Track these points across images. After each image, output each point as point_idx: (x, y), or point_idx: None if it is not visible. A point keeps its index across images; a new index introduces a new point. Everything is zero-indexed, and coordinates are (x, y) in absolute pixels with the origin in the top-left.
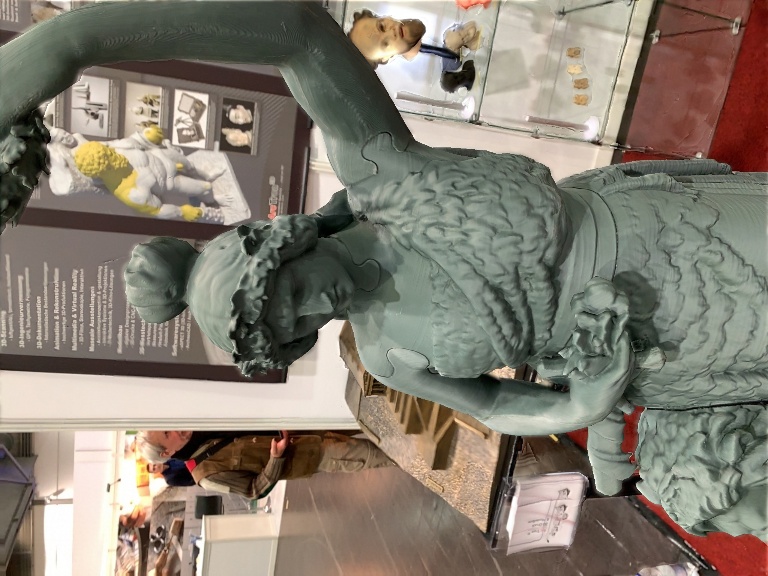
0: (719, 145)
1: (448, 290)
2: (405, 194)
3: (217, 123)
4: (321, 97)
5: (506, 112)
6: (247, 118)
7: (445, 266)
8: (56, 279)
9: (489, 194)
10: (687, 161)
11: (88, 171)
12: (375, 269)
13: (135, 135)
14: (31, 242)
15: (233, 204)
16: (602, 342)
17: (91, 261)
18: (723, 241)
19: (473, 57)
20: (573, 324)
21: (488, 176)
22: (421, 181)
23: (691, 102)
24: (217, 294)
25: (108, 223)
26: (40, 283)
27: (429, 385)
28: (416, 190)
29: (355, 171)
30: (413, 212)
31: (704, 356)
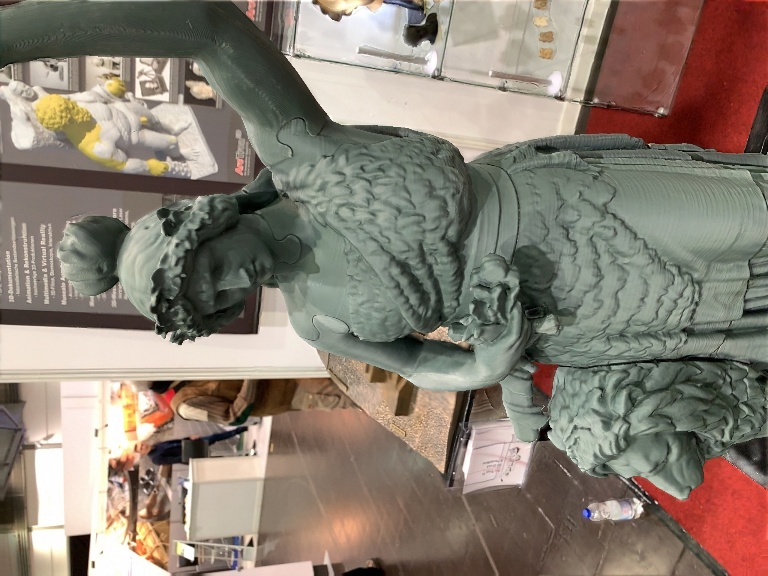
0: (680, 100)
1: (360, 264)
2: (318, 176)
3: (180, 75)
4: (233, 87)
5: (474, 64)
6: None
7: (355, 243)
8: (24, 234)
9: (394, 177)
10: (601, 136)
11: (50, 125)
12: (296, 244)
13: (97, 88)
14: None
15: (200, 158)
16: (495, 312)
17: (58, 216)
18: (618, 217)
19: (436, 10)
20: None
21: (394, 159)
22: (332, 164)
23: (660, 54)
24: (140, 272)
25: (74, 178)
26: (8, 238)
27: (353, 347)
28: (328, 173)
29: (272, 154)
30: (326, 193)
31: (599, 321)
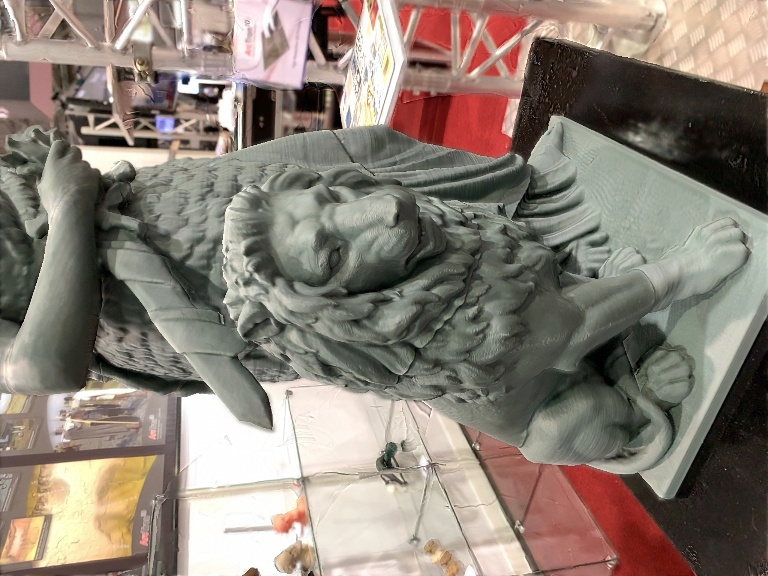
0: (611, 534)
1: None
2: None
3: None
4: None
5: None
6: None
7: None
8: None
9: None
10: None
11: None
12: None
13: None
14: None
15: None
16: (33, 138)
17: None
18: None
19: None
20: None
21: None
22: None
23: None
24: None
25: None
26: None
27: None
28: None
29: None
30: None
31: (197, 181)
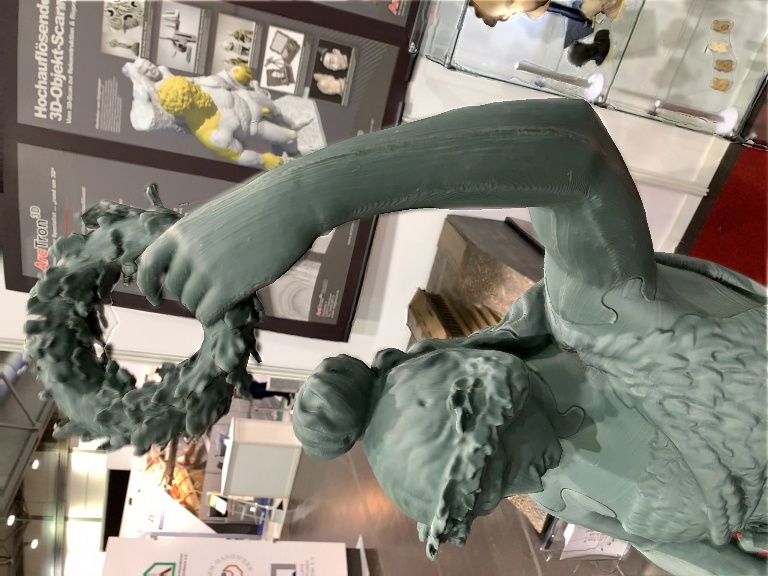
0: None
1: (672, 465)
2: (646, 354)
3: (310, 67)
4: (579, 244)
5: (623, 82)
6: (342, 64)
7: (682, 448)
8: None
9: (760, 375)
10: None
11: (171, 108)
12: (579, 417)
13: (222, 73)
14: (108, 177)
15: None
16: None
17: (166, 202)
18: None
19: (609, 26)
20: None
21: (759, 348)
22: (672, 343)
23: None
24: (417, 472)
25: (186, 164)
26: None
27: (599, 523)
28: (663, 353)
29: (585, 314)
30: (651, 375)
31: None
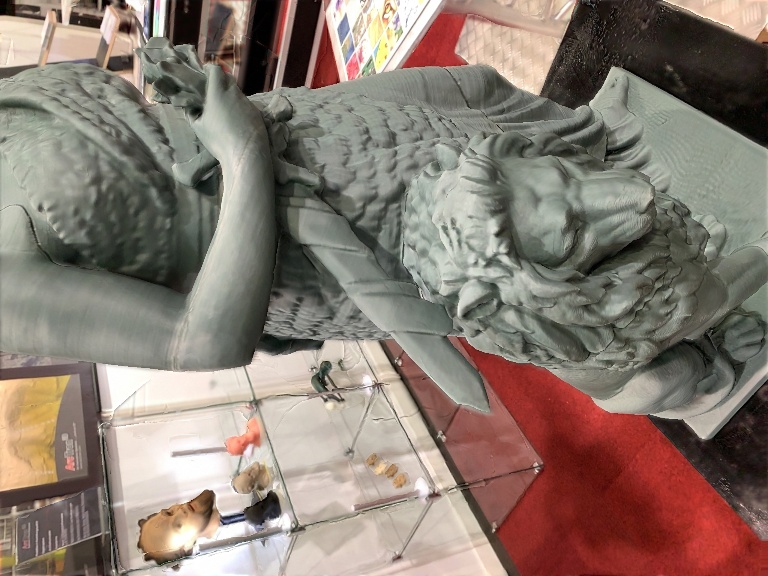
0: (539, 444)
1: (12, 124)
2: None
3: None
4: None
5: (358, 560)
6: None
7: None
8: None
9: None
10: None
11: None
12: None
13: None
14: None
15: None
16: (176, 58)
17: None
18: None
19: (271, 489)
20: (191, 137)
21: None
22: None
23: None
24: None
25: None
26: None
27: (59, 277)
28: None
29: None
30: None
31: (350, 125)
